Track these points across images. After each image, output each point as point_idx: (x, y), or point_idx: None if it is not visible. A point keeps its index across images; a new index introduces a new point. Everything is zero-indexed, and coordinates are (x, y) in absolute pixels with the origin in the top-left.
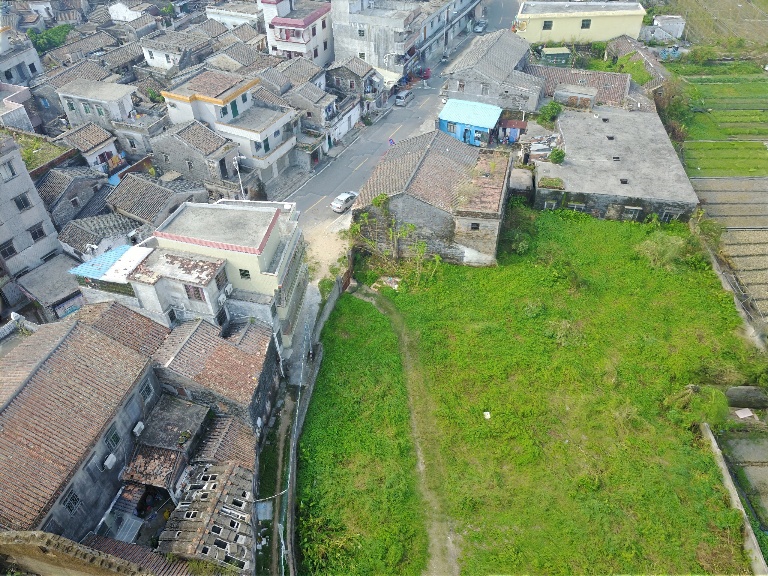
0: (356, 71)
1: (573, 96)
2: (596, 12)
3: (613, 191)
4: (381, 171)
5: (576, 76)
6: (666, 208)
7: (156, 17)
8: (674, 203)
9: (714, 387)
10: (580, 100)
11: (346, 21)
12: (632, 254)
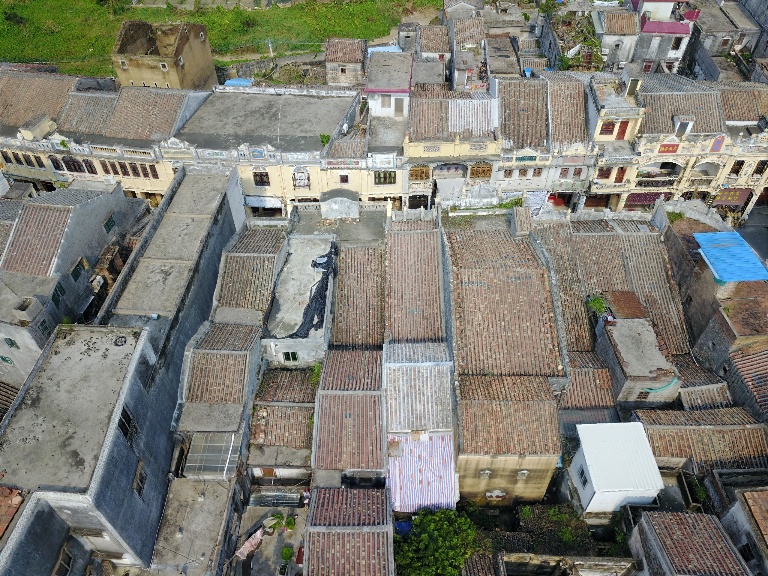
0: None
1: None
2: None
3: None
4: None
5: None
6: None
7: None
8: None
9: None
10: None
11: None
12: (9, 6)
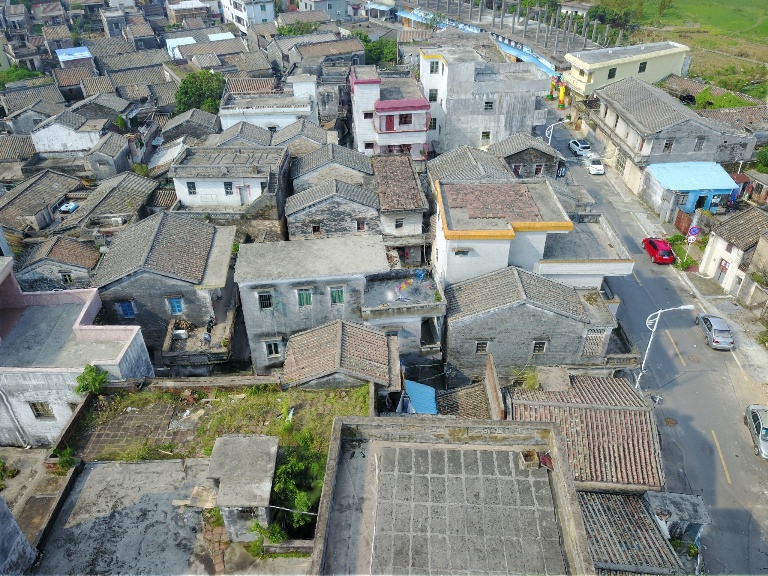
0: (546, 151)
1: None
2: (651, 53)
3: None
4: None
5: (729, 115)
6: None
7: (124, 136)
8: None
9: None
10: None
11: (467, 93)
12: None
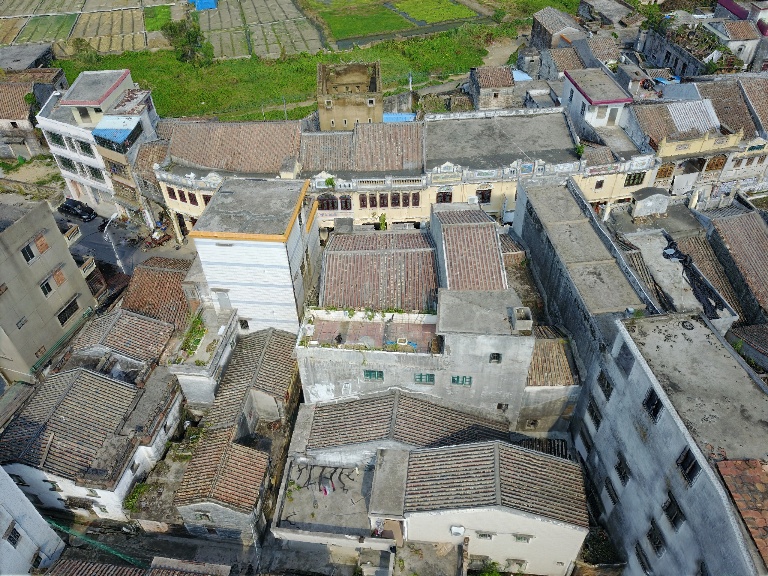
0: None
1: None
2: None
3: (26, 63)
4: None
5: None
6: (47, 57)
7: None
8: (46, 52)
9: (194, 49)
10: None
11: None
12: None
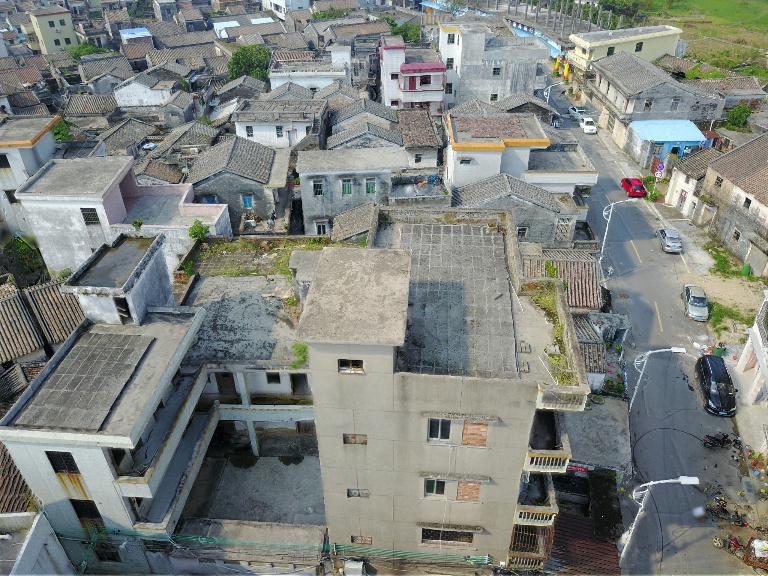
0: (542, 106)
1: (744, 99)
2: (647, 34)
3: None
4: (759, 186)
5: (708, 85)
6: None
7: (190, 94)
8: None
9: None
10: (750, 102)
11: (478, 60)
12: None
